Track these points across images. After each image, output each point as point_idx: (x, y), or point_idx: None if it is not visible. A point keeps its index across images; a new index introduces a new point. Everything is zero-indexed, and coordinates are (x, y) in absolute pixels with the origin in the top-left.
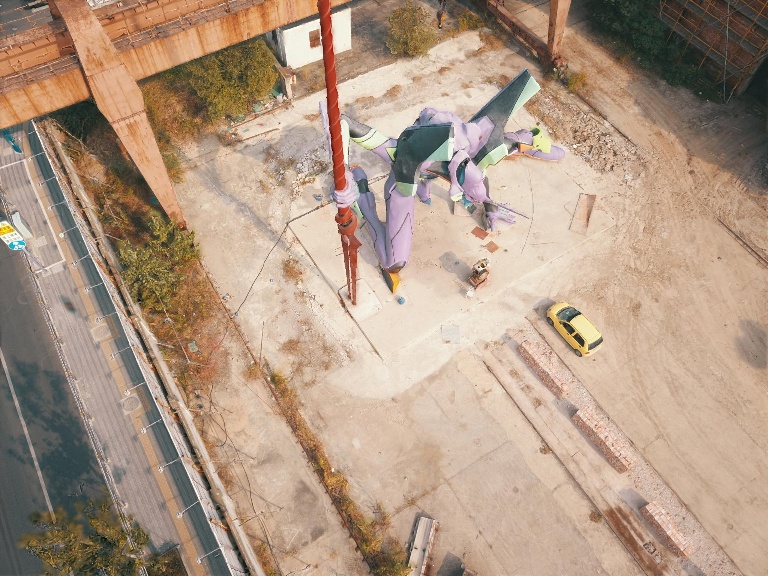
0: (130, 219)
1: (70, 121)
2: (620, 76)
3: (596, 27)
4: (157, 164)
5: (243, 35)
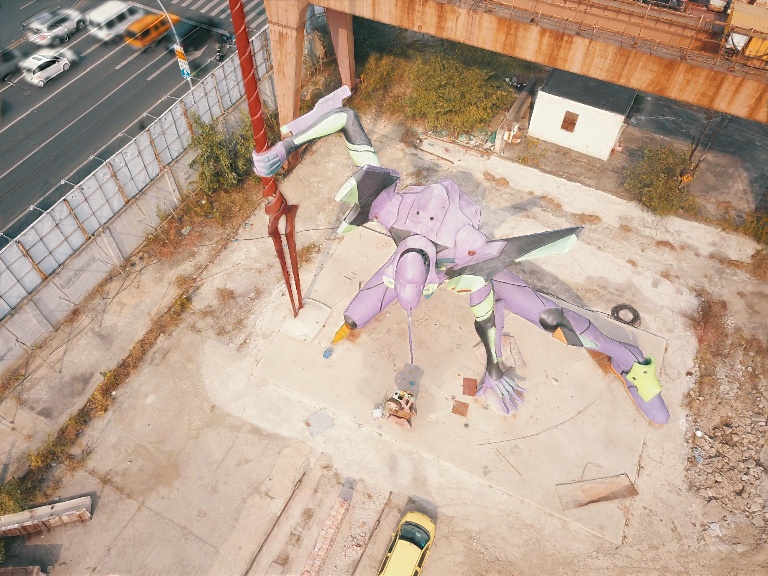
0: None
1: (329, 43)
2: None
3: None
4: (290, 85)
5: (415, 24)
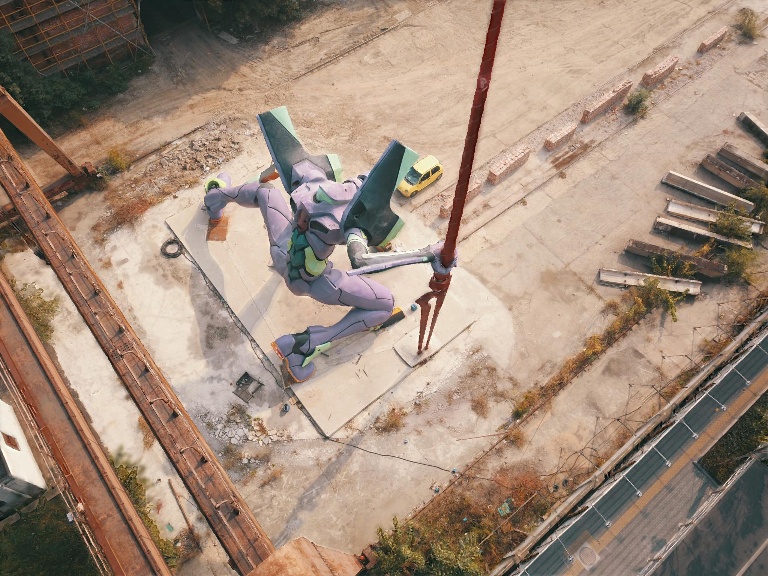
0: None
1: None
2: (107, 127)
3: (21, 141)
4: None
5: None
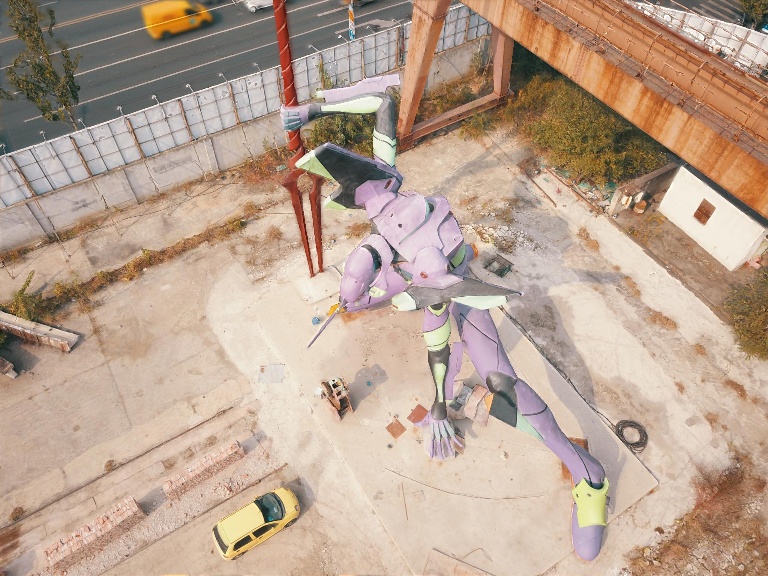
0: (416, 114)
1: None
2: None
3: None
4: (416, 70)
5: (533, 45)
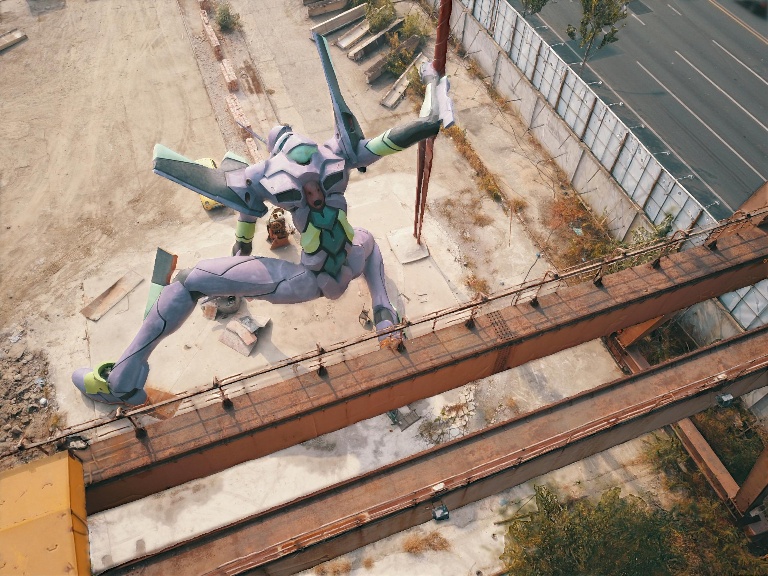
0: None
1: None
2: None
3: None
4: None
5: None
